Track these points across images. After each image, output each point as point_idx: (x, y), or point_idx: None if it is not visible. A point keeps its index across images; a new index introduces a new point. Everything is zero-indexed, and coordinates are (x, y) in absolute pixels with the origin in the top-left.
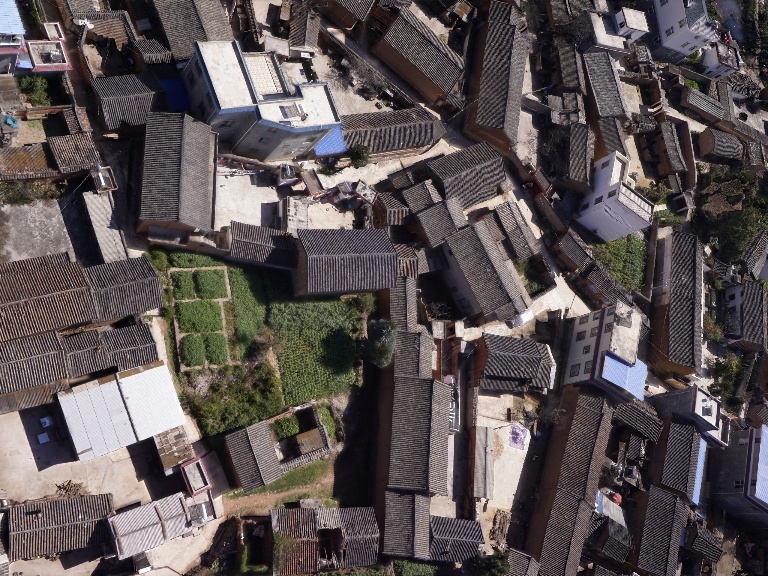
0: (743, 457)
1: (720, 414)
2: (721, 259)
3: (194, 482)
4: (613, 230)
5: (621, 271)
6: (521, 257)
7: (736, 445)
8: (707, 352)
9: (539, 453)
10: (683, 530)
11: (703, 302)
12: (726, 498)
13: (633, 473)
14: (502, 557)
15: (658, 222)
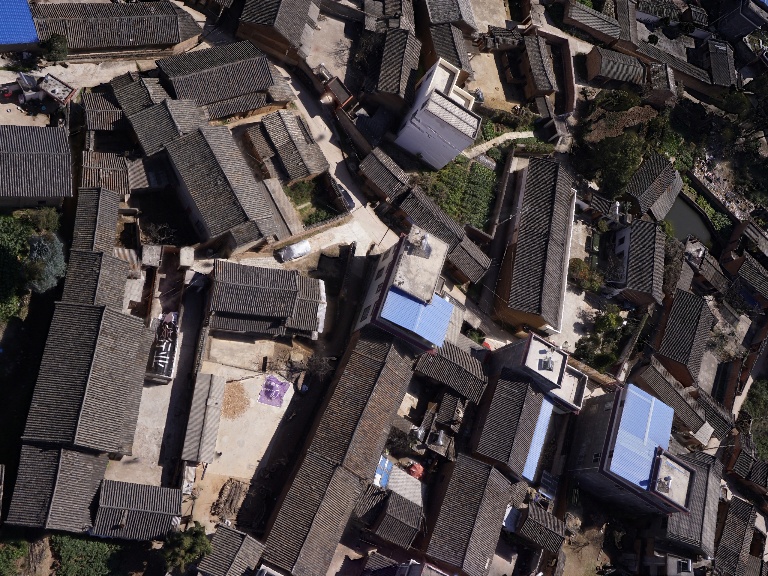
0: (606, 424)
1: (572, 371)
2: (603, 195)
3: None
4: (438, 152)
5: (458, 204)
6: (293, 176)
7: (601, 411)
8: (584, 304)
9: (305, 412)
10: (514, 512)
11: (583, 246)
12: (584, 475)
13: (438, 439)
14: (197, 533)
15: (514, 149)
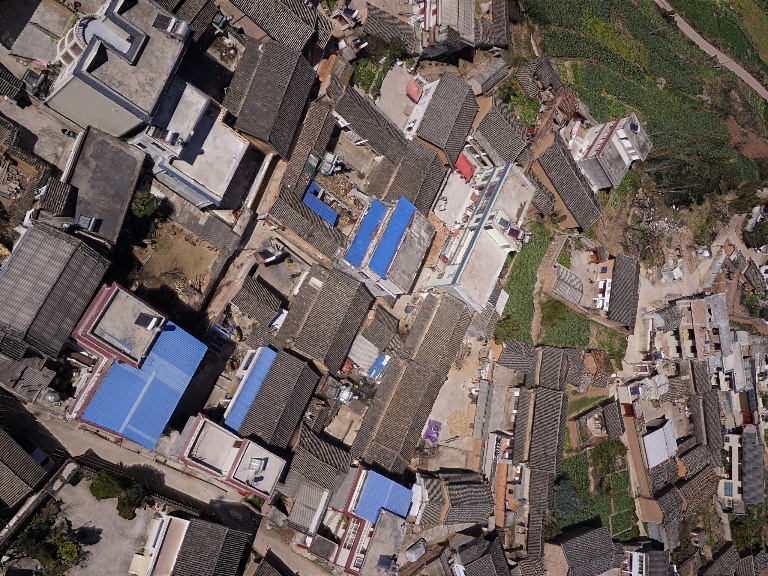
0: None
1: None
2: None
3: (638, 406)
4: None
5: None
6: None
7: None
8: (73, 575)
9: None
10: None
11: None
12: None
13: None
14: None
15: None
